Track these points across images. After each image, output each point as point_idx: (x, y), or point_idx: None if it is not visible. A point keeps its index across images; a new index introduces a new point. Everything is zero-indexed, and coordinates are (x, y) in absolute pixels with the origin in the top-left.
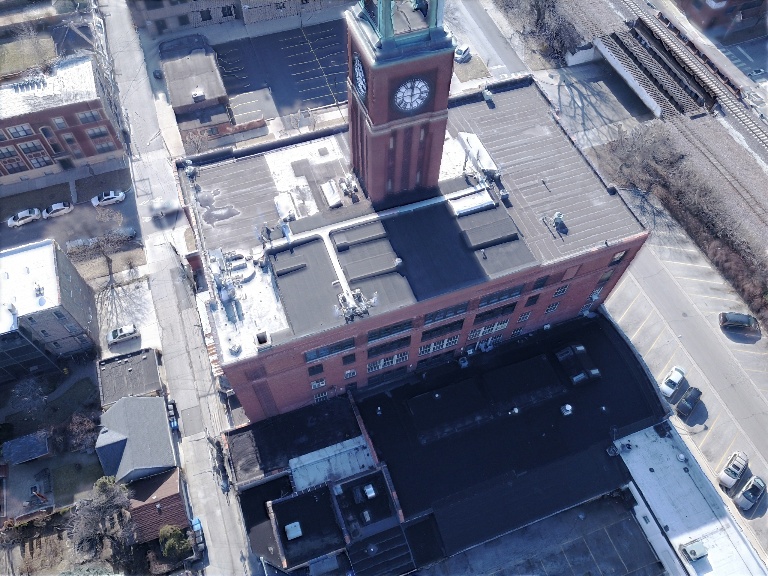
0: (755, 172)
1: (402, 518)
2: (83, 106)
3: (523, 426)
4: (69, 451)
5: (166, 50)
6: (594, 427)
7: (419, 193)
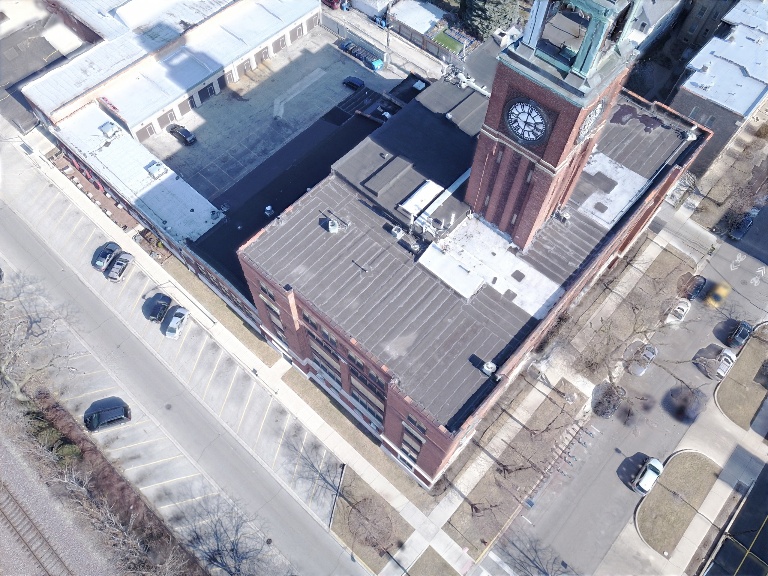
0: None
1: (357, 111)
2: None
3: (299, 190)
4: None
5: None
6: (243, 216)
7: None
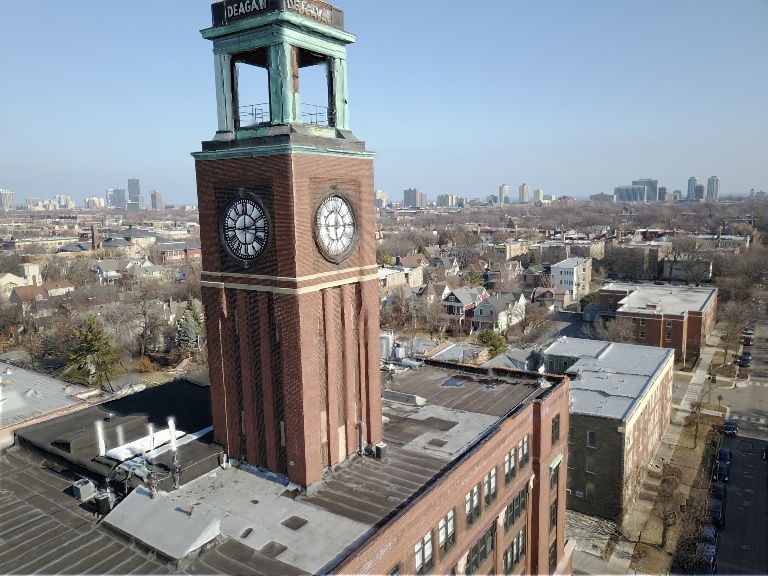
0: None
1: None
2: None
3: None
4: None
5: None
6: None
7: None
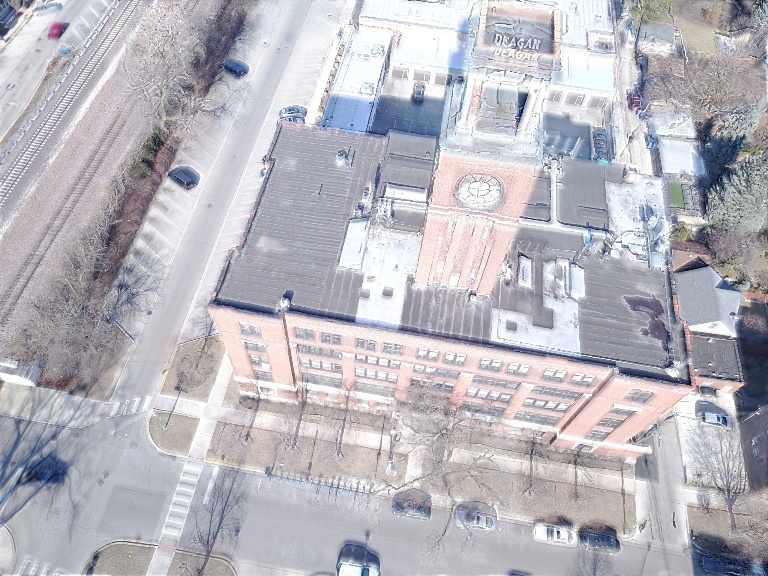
0: (5, 254)
1: None
2: None
3: None
4: (759, 339)
5: None
6: None
7: None
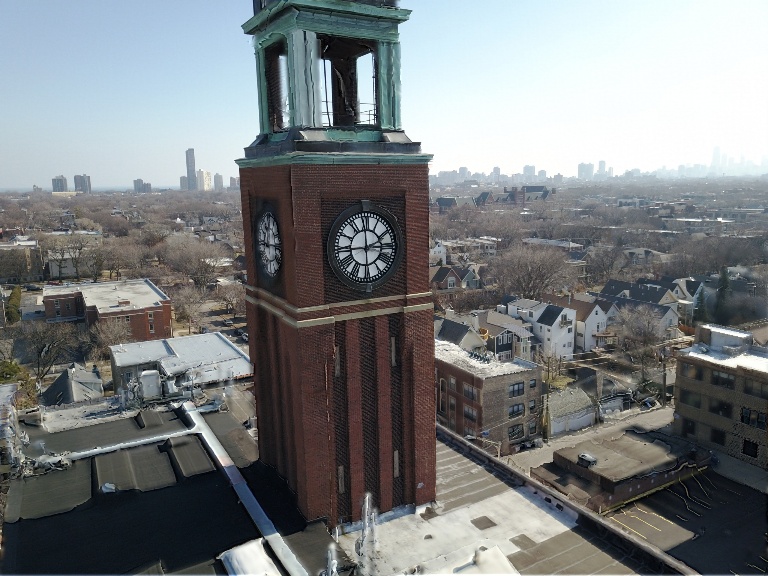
0: None
1: None
2: (471, 378)
3: None
4: None
5: (648, 434)
6: None
7: (286, 505)
